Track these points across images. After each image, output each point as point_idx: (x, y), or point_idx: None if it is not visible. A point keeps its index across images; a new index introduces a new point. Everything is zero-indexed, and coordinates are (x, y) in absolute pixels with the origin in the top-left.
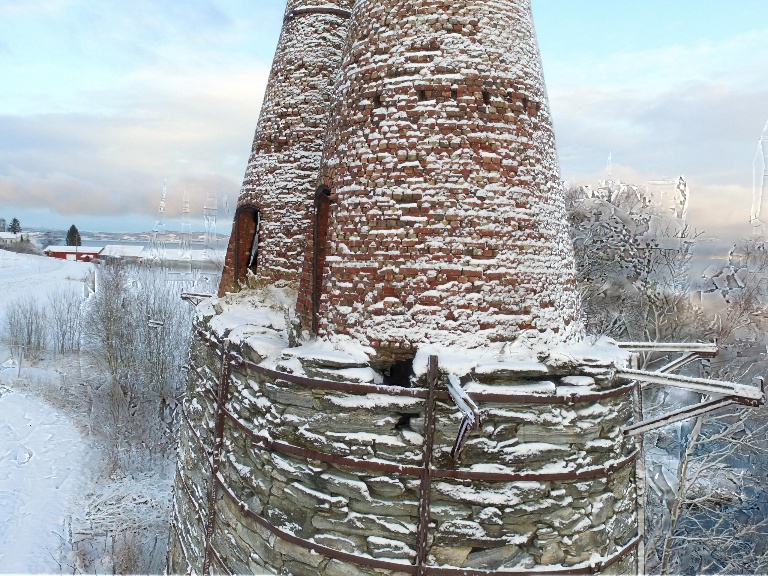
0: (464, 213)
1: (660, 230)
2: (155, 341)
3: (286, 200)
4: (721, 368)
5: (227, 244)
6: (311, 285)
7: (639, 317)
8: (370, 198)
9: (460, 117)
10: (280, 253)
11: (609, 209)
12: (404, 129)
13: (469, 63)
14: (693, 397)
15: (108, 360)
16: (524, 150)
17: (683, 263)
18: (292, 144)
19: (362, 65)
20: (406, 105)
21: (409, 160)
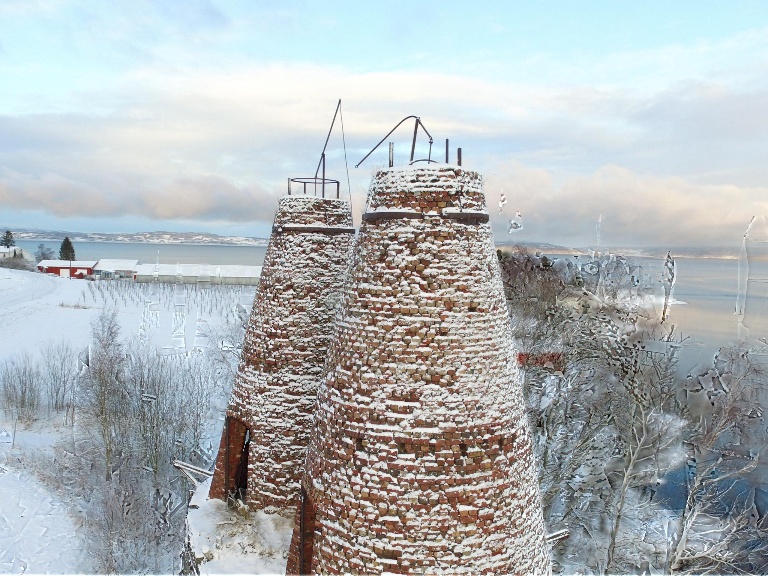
0: (442, 572)
1: (647, 332)
2: (149, 415)
3: (275, 425)
4: (707, 467)
5: (220, 317)
6: (298, 568)
7: (627, 413)
8: (353, 545)
9: (438, 472)
10: (269, 479)
11: (597, 304)
12: (385, 481)
13: (447, 416)
14: (679, 497)
15: (102, 433)
16: (500, 493)
17: (669, 366)
18: (281, 367)
19: (345, 399)
20: (387, 456)
21: (390, 514)
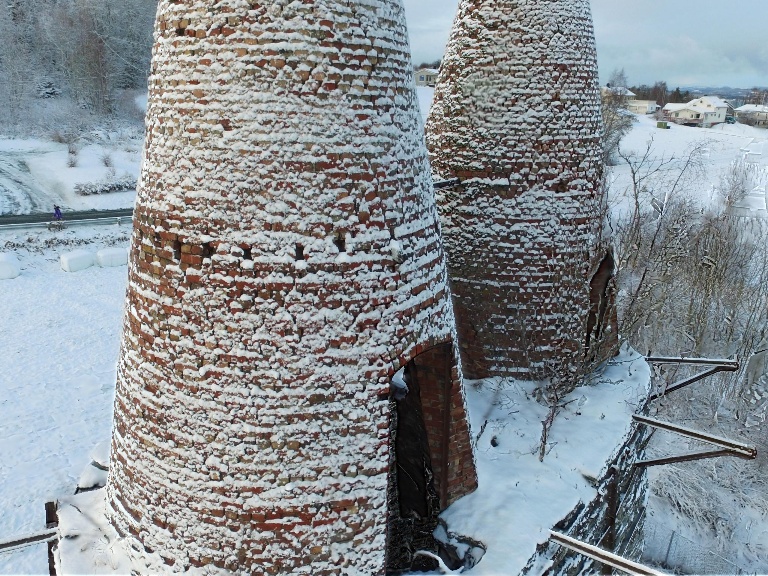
0: None
1: None
2: None
3: None
4: None
5: None
6: None
7: None
8: None
9: None
10: None
11: None
12: None
13: None
14: None
15: None
16: (166, 315)
17: None
18: None
19: None
20: None
21: None
